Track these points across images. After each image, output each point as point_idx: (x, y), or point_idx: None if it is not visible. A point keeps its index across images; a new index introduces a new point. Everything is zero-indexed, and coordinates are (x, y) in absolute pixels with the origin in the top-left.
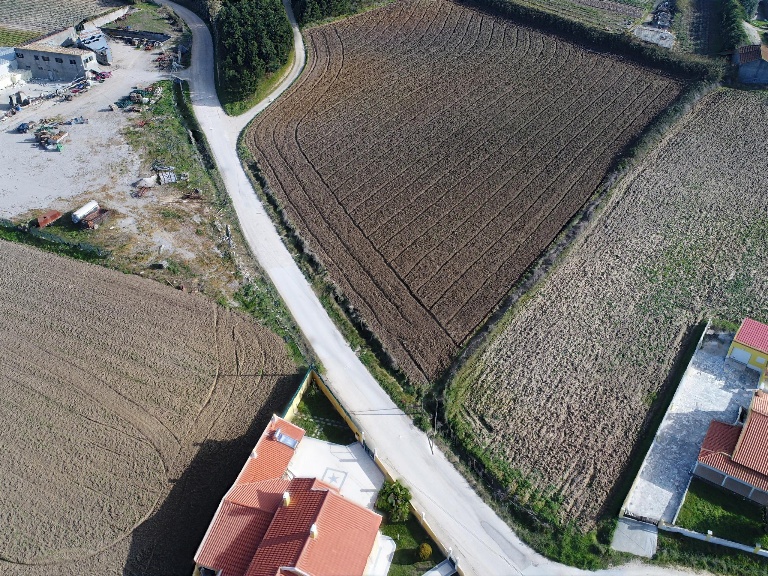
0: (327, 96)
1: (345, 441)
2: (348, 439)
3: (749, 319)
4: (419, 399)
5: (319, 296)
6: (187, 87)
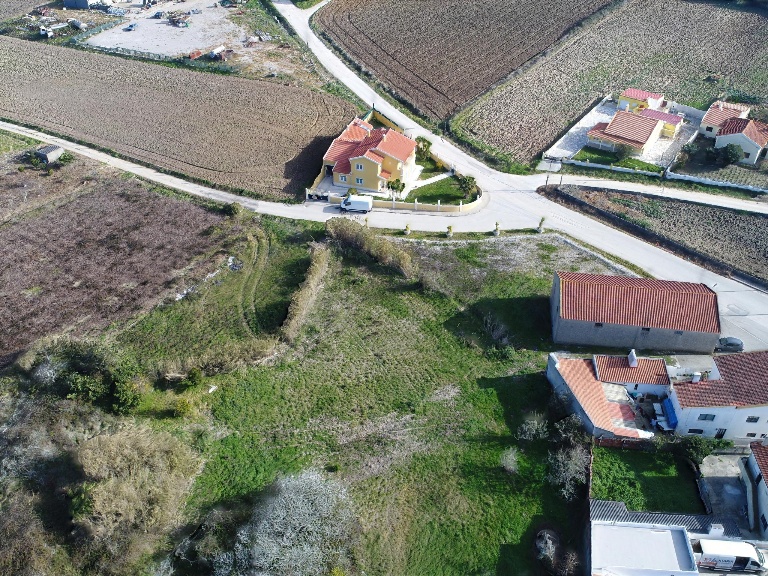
0: None
1: None
2: None
3: None
4: (436, 126)
5: (373, 88)
6: None
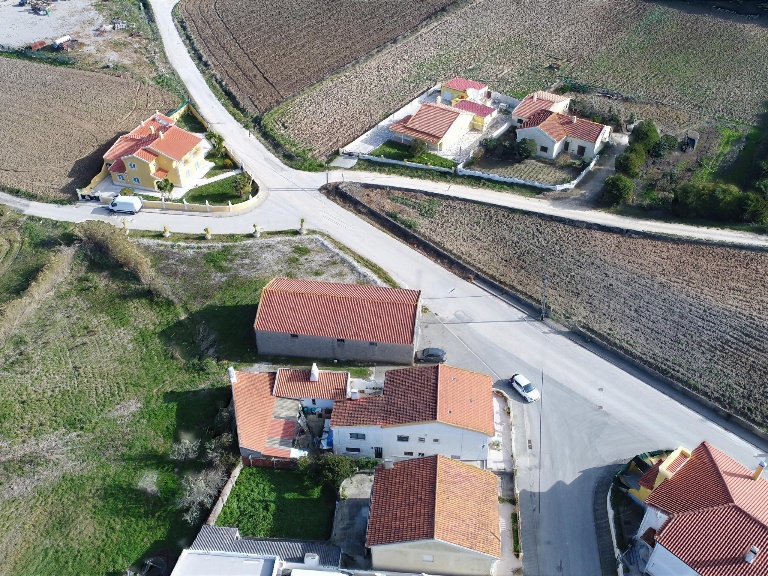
0: None
1: (200, 131)
2: (202, 131)
3: (459, 78)
4: (251, 119)
5: (206, 80)
6: None
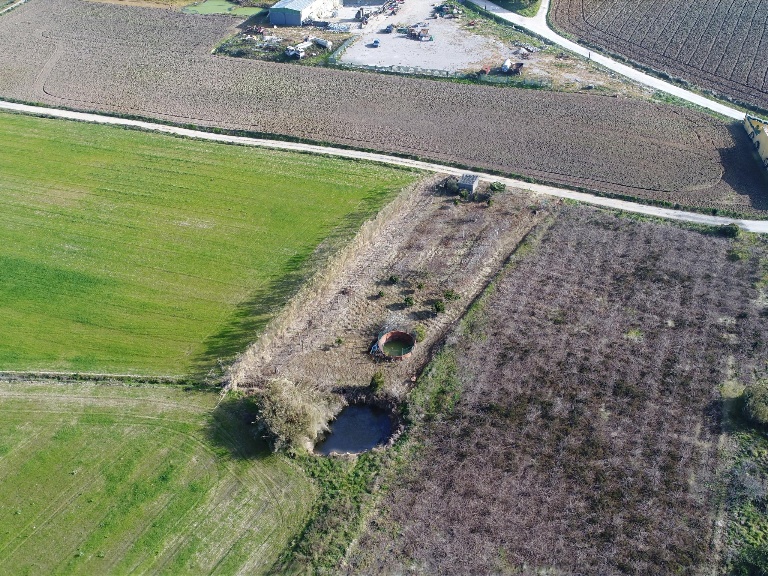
0: (586, 3)
1: None
2: None
3: None
4: None
5: (703, 96)
6: (473, 3)
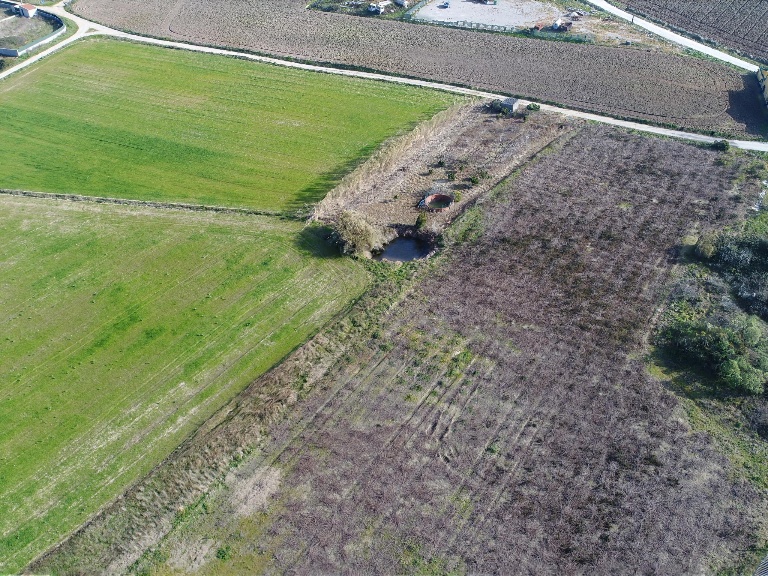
0: None
1: None
2: None
3: None
4: None
5: (728, 54)
6: None
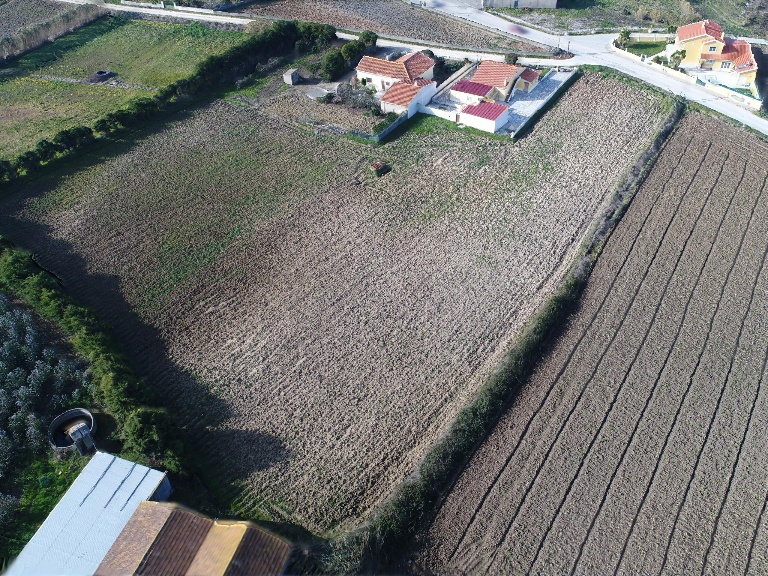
0: None
1: None
2: None
3: (493, 120)
4: None
5: None
6: None
